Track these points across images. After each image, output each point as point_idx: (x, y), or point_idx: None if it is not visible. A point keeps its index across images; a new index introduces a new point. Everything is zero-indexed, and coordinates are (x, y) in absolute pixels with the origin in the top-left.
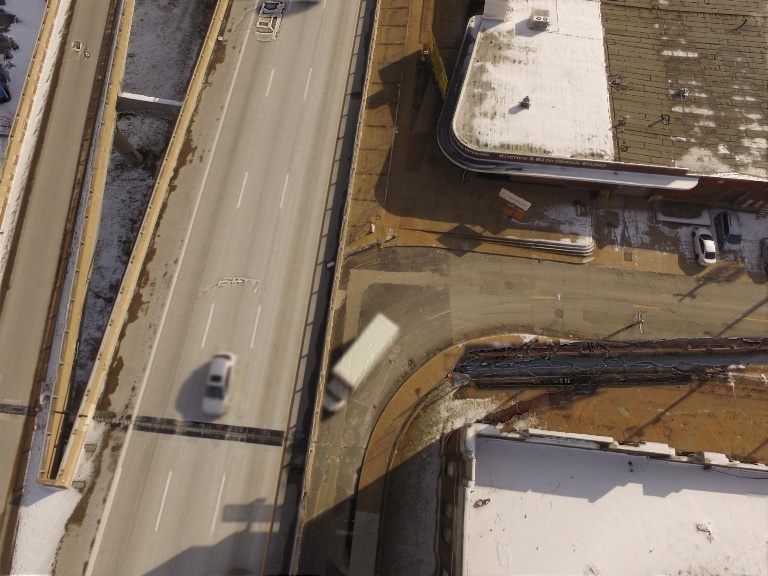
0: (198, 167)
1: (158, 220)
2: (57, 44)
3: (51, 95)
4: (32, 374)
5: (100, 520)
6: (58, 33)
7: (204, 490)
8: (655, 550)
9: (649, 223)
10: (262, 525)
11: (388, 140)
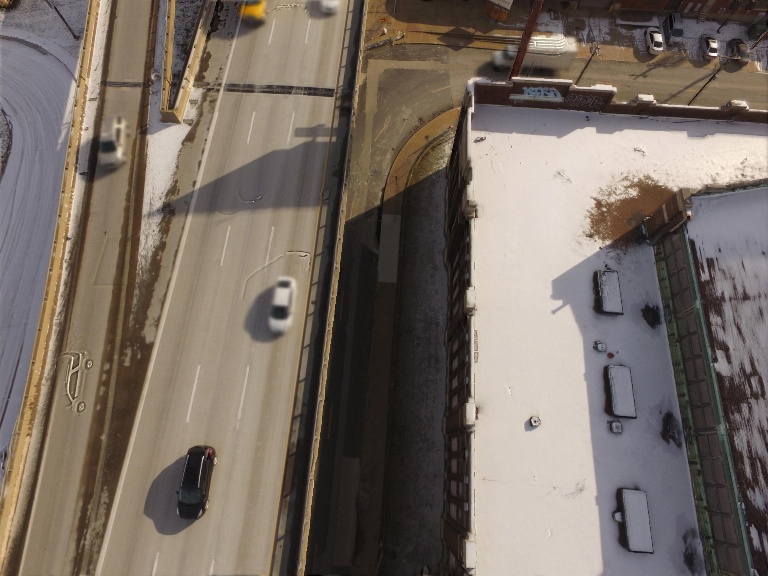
0: None
1: None
2: None
3: None
4: (143, 64)
5: (207, 139)
6: None
7: (280, 121)
8: (604, 162)
9: (610, 27)
10: (324, 138)
11: None
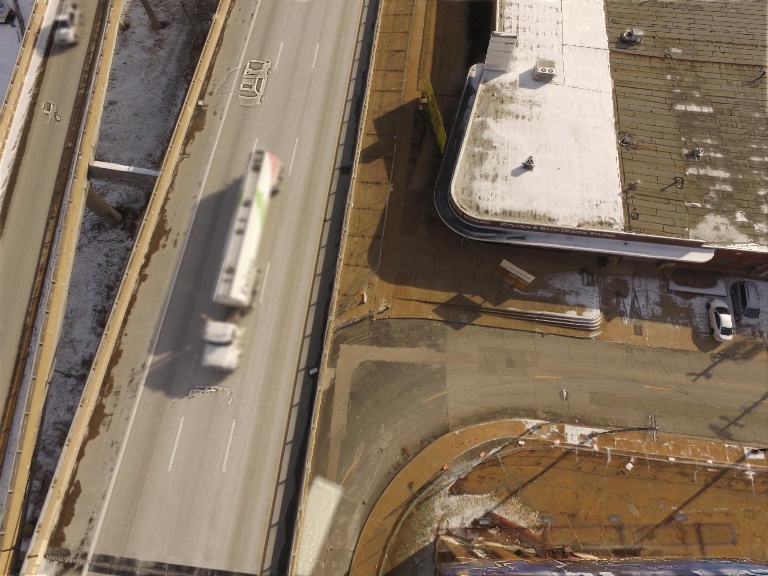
0: (171, 253)
1: (126, 316)
2: (26, 105)
3: (17, 165)
4: None
5: None
6: (28, 93)
7: None
8: None
9: (660, 292)
10: None
11: (383, 198)
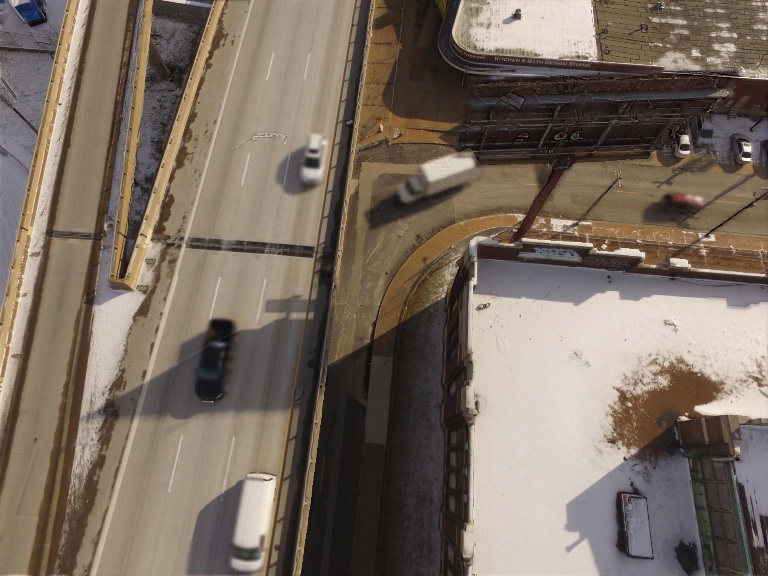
0: (230, 49)
1: (197, 91)
2: None
3: None
4: (96, 209)
5: (162, 313)
6: None
7: (249, 290)
8: (629, 339)
9: None
10: (299, 314)
11: (393, 55)
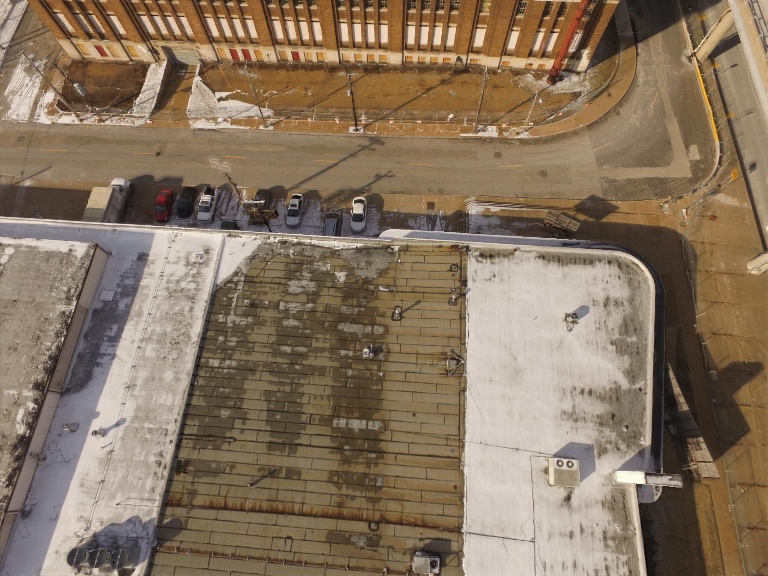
0: None
1: None
2: None
3: None
4: None
5: None
6: None
7: None
8: None
9: None
10: None
11: None
